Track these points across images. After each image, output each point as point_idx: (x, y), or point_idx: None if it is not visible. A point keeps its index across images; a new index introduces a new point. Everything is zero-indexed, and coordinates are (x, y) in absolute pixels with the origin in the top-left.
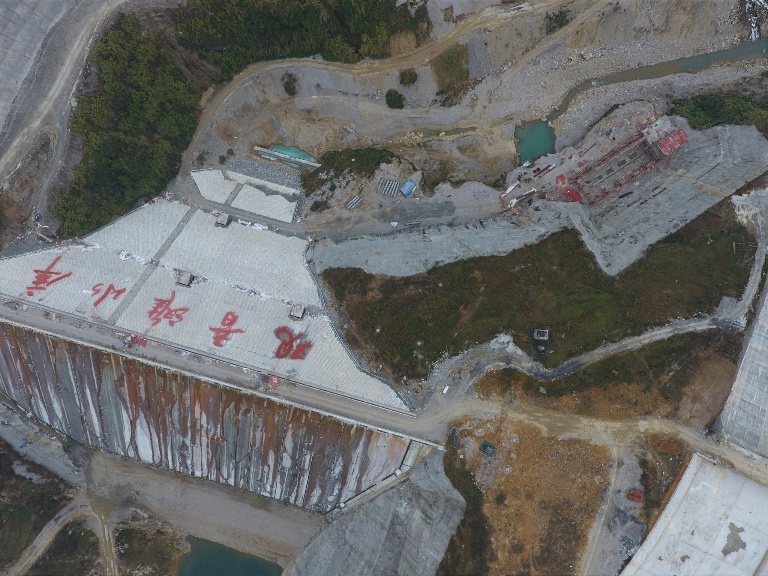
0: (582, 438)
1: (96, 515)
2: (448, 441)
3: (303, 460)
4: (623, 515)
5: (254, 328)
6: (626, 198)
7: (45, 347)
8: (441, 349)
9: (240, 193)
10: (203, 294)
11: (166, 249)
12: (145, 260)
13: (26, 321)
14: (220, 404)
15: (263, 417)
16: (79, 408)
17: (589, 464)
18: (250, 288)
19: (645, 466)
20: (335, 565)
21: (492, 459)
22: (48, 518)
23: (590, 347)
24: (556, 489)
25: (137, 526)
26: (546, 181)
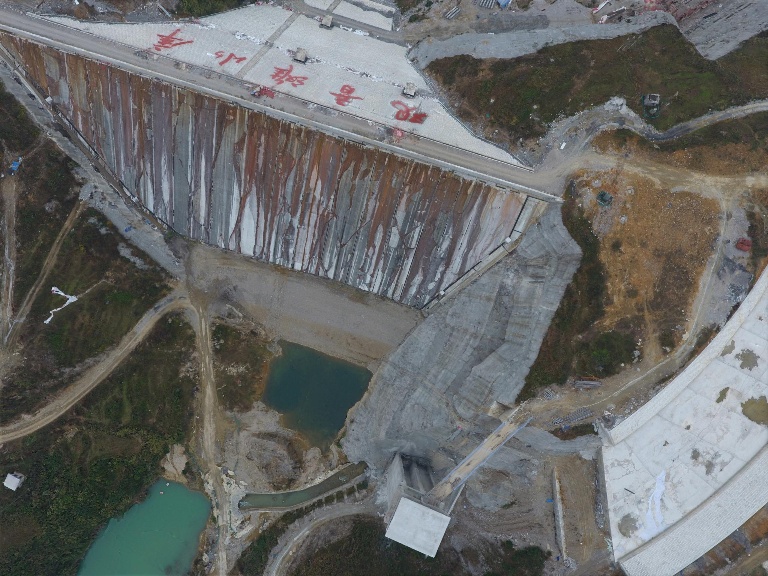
0: (693, 191)
1: (194, 308)
2: (566, 191)
3: (412, 235)
4: (732, 264)
5: (371, 98)
6: (711, 18)
7: (170, 104)
8: (557, 112)
9: (339, 6)
10: (319, 70)
11: (278, 36)
12: (260, 41)
13: (156, 70)
14: (339, 166)
15: (381, 179)
16: (189, 186)
17: (700, 215)
18: (362, 71)
19: (753, 218)
20: (437, 346)
21: (608, 209)
22: (149, 305)
23: (697, 114)
24: (669, 238)
25: (232, 324)
26: (635, 0)
